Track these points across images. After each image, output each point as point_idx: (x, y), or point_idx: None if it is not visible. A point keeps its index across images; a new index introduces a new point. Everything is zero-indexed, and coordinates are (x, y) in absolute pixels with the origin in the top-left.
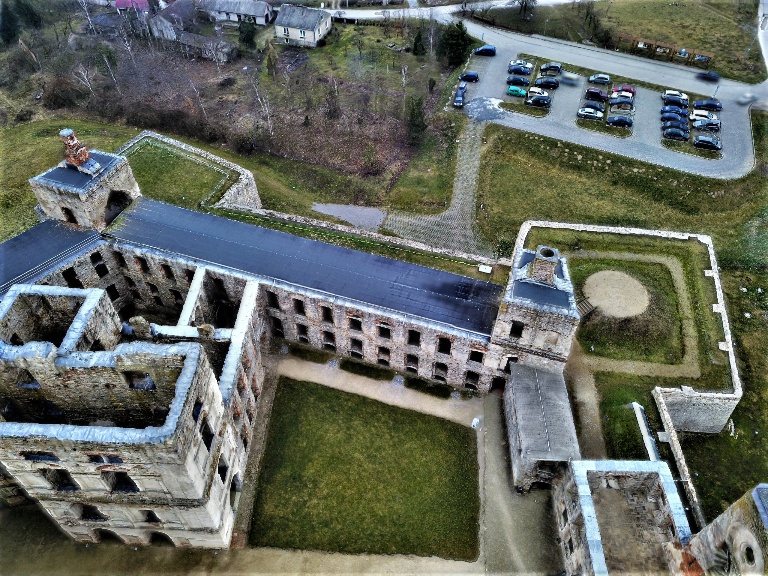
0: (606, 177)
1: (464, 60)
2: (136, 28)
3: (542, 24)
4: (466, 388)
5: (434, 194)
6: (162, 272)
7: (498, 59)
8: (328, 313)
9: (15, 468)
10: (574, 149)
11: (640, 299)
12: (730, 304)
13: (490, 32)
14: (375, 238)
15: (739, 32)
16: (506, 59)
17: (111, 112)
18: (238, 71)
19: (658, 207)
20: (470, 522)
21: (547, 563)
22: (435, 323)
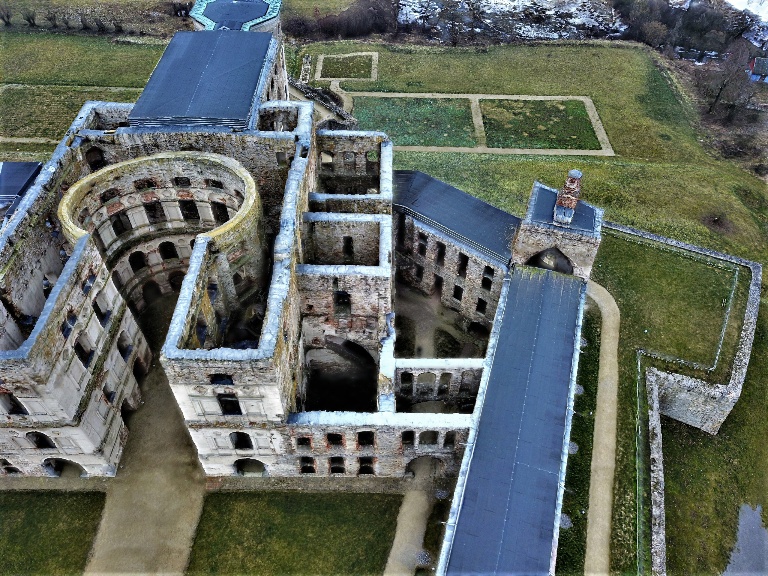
0: None
1: None
2: None
3: None
4: None
5: None
6: None
7: None
8: None
9: None
10: None
11: None
12: None
13: None
14: None
15: None
16: None
17: None
18: None
19: None
20: None
21: None
22: None
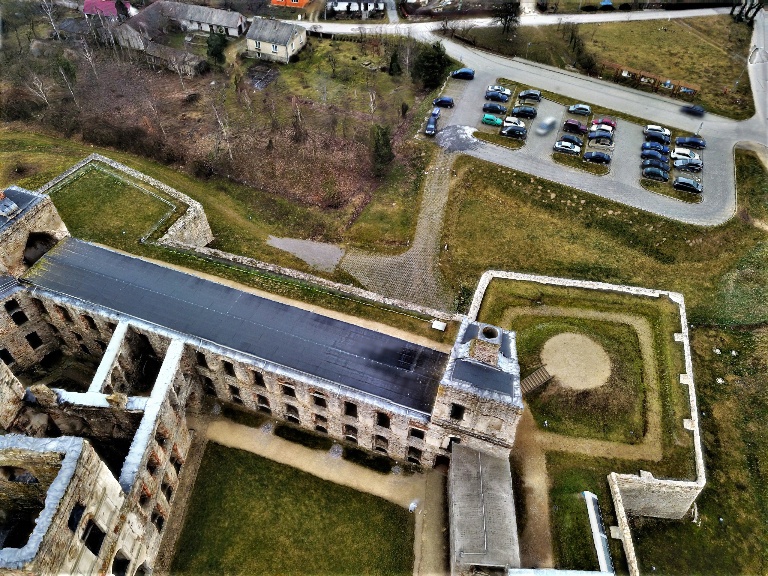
0: (579, 218)
1: (440, 83)
2: (101, 36)
3: (525, 46)
4: (409, 462)
5: (397, 231)
6: (85, 322)
7: (476, 83)
8: (260, 377)
9: None
10: (548, 186)
11: (601, 368)
12: (702, 367)
13: (470, 53)
14: (324, 285)
15: (728, 62)
16: (484, 84)
17: (67, 127)
18: (205, 86)
19: (632, 254)
20: None
21: None
22: (372, 397)
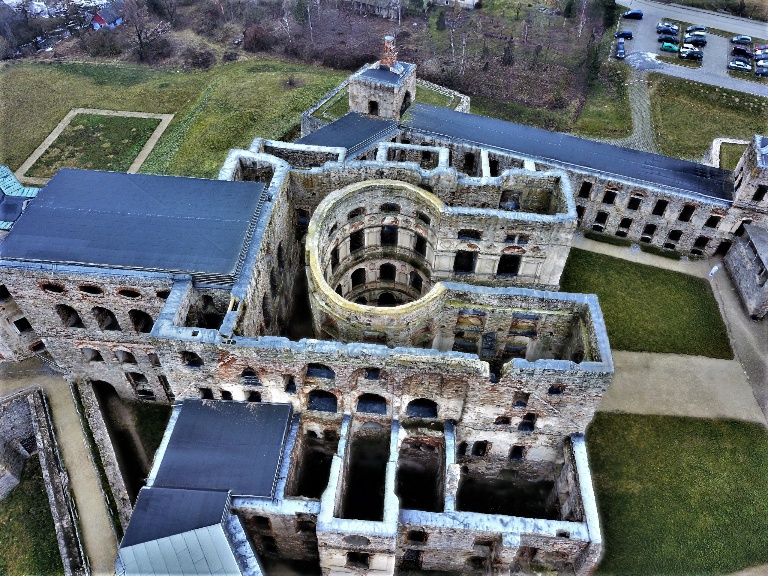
0: (762, 116)
1: (615, 22)
2: None
3: None
4: (692, 254)
5: (616, 124)
6: None
7: (645, 22)
8: (586, 189)
9: (442, 248)
10: (731, 93)
11: None
12: None
13: None
14: None
15: None
16: (652, 22)
17: (308, 55)
18: (409, 26)
19: None
20: (721, 336)
21: None
22: (685, 192)
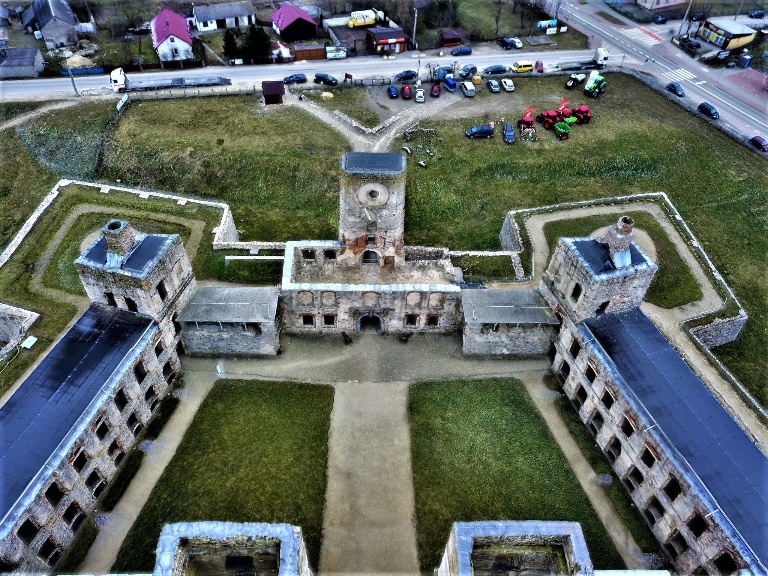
0: None
1: None
2: None
3: None
4: (170, 384)
5: None
6: None
7: None
8: (52, 493)
9: None
10: None
11: None
12: None
13: None
14: None
15: None
16: None
17: None
18: None
19: None
20: (303, 389)
21: (336, 343)
22: (122, 365)
